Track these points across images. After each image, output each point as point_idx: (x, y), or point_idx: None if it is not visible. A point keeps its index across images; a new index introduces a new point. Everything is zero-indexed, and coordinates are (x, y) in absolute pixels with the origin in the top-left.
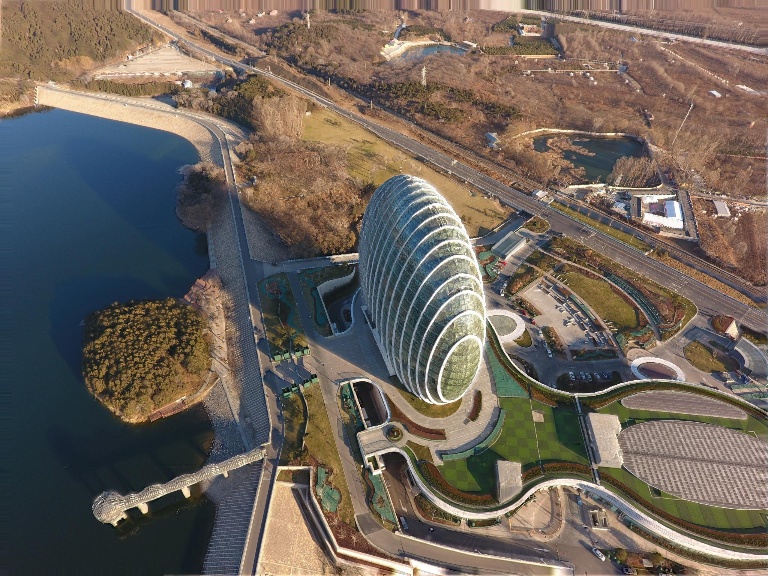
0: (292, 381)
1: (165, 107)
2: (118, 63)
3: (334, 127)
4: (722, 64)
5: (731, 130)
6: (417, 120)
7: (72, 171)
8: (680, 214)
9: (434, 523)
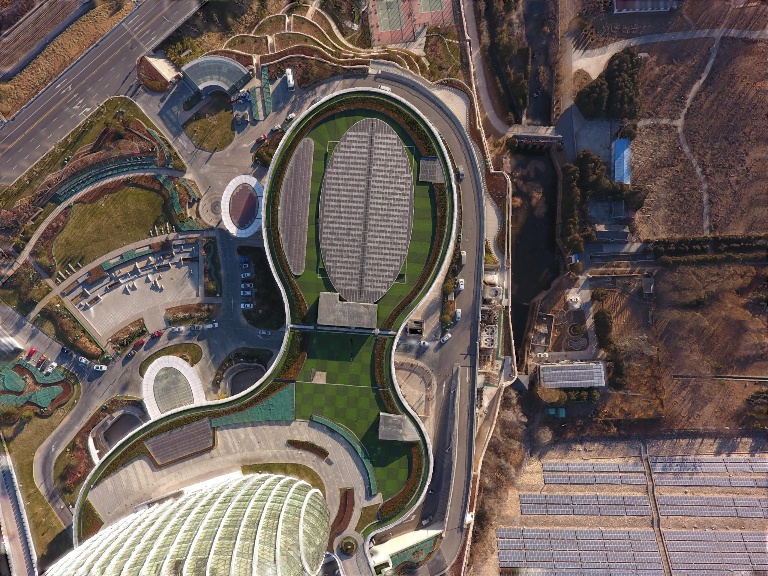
0: None
1: None
2: None
3: None
4: None
5: None
6: None
7: None
8: None
9: None
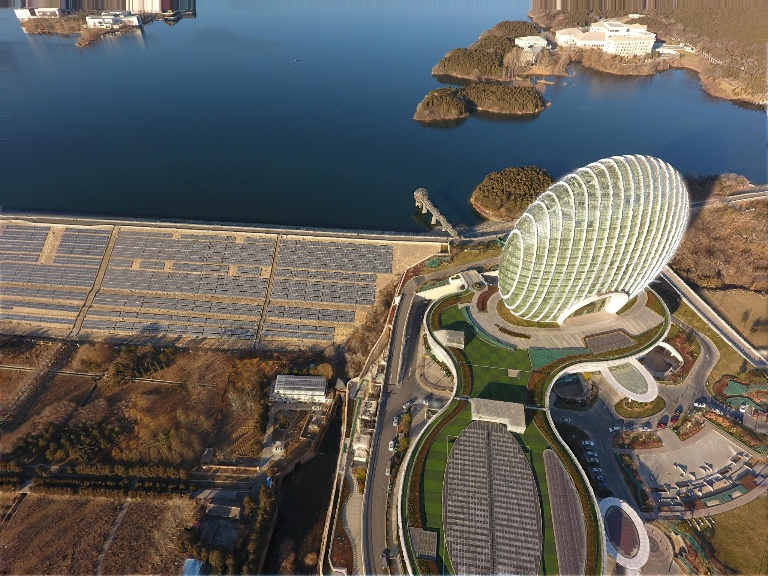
0: None
1: None
2: None
3: None
4: None
5: None
6: None
7: (680, 137)
8: None
9: None
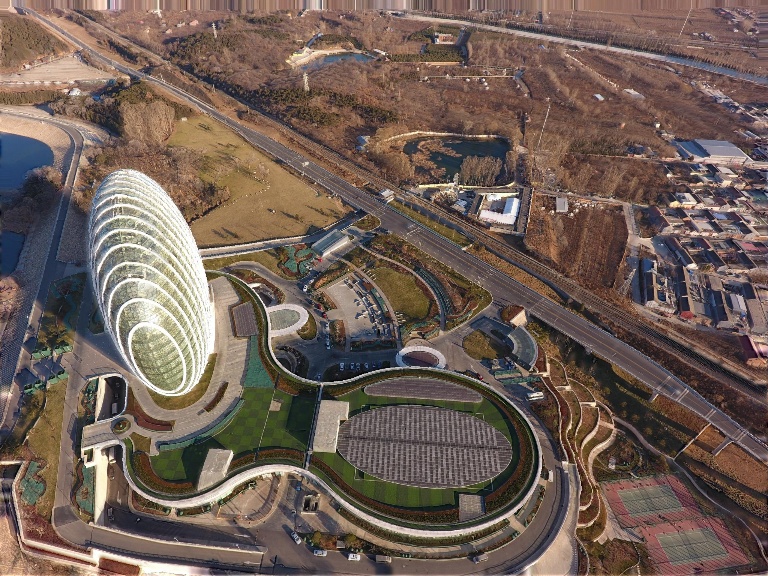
0: (43, 378)
1: (39, 114)
2: (11, 72)
3: (205, 132)
4: (619, 69)
5: (600, 131)
6: (293, 124)
7: None
8: (516, 210)
9: (143, 513)
